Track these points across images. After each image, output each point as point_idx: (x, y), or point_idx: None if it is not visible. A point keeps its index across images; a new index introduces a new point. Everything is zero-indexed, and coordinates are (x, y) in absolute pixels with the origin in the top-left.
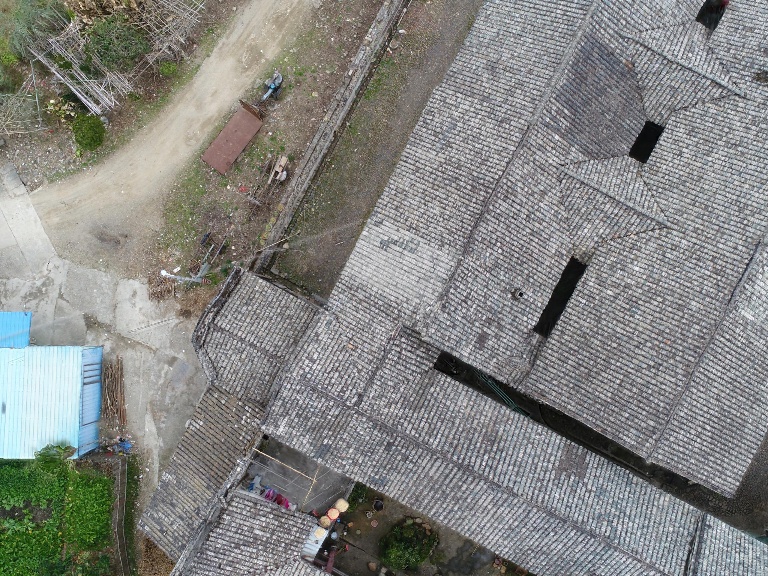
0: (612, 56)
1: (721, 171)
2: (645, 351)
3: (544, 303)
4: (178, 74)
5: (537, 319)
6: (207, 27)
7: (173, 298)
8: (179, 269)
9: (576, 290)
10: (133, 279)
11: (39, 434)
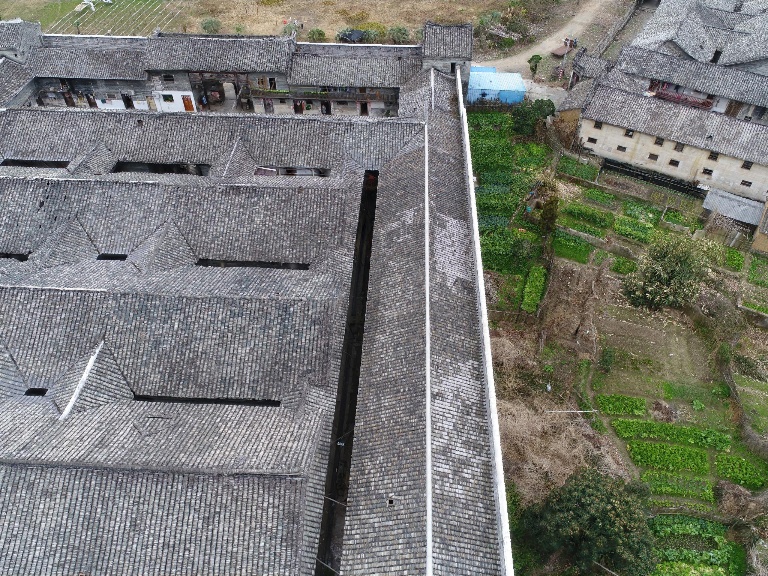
0: (708, 10)
1: (761, 24)
2: (759, 47)
3: (712, 55)
4: (534, 43)
5: (711, 58)
6: (542, 36)
7: (544, 83)
8: (545, 78)
9: (723, 50)
10: (526, 79)
11: (508, 86)
